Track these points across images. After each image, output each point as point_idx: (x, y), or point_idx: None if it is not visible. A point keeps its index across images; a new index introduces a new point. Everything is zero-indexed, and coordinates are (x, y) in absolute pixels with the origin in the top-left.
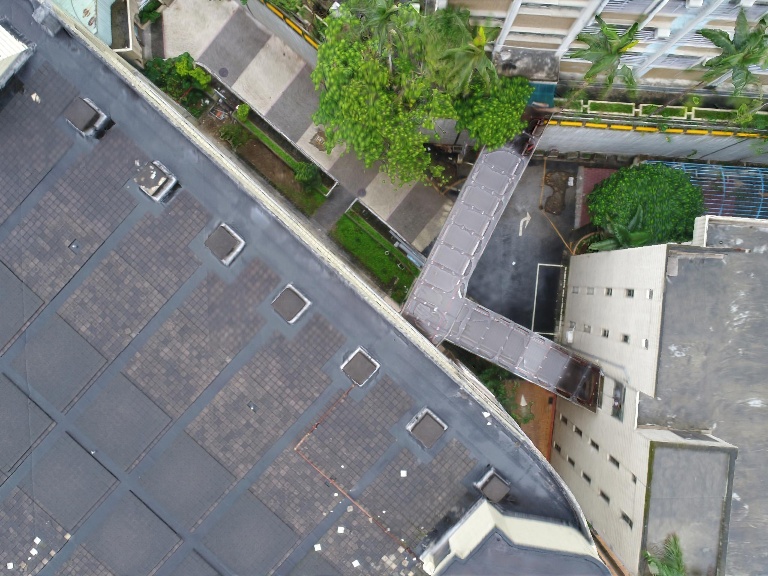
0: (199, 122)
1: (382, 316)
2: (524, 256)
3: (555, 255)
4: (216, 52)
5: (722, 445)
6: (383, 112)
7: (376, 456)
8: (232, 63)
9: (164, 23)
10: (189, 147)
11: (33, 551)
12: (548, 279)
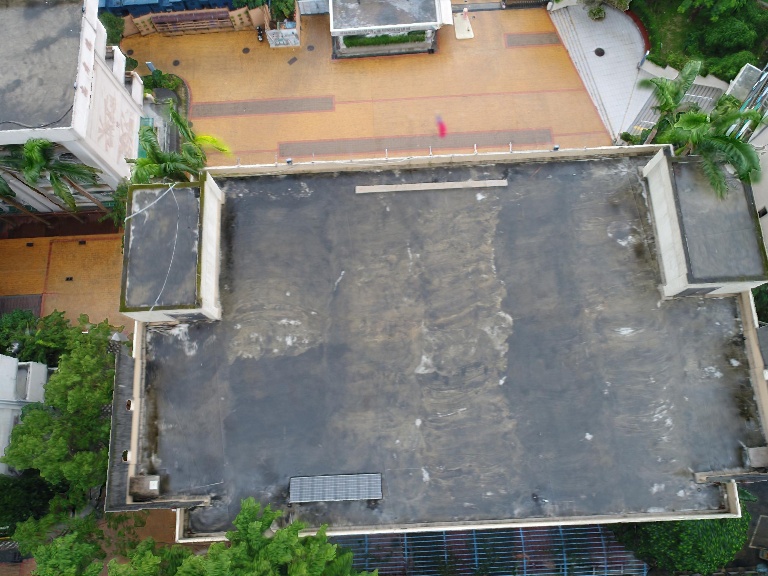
0: None
1: None
2: None
3: None
4: None
5: None
6: None
7: None
8: None
9: None
10: None
11: None
12: None
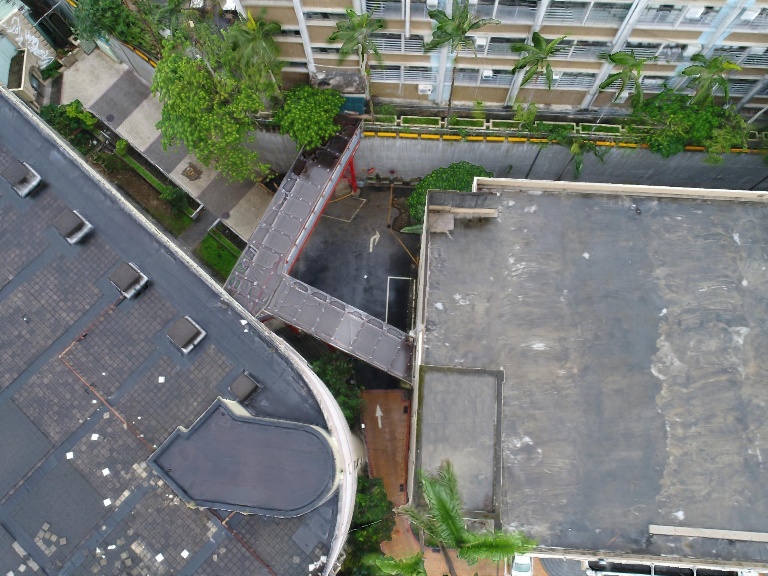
0: (86, 159)
1: (154, 236)
2: (375, 270)
3: (404, 269)
4: (105, 102)
5: (490, 369)
6: (201, 105)
7: (137, 363)
8: (118, 111)
9: (64, 80)
10: (6, 106)
11: None
12: (398, 291)
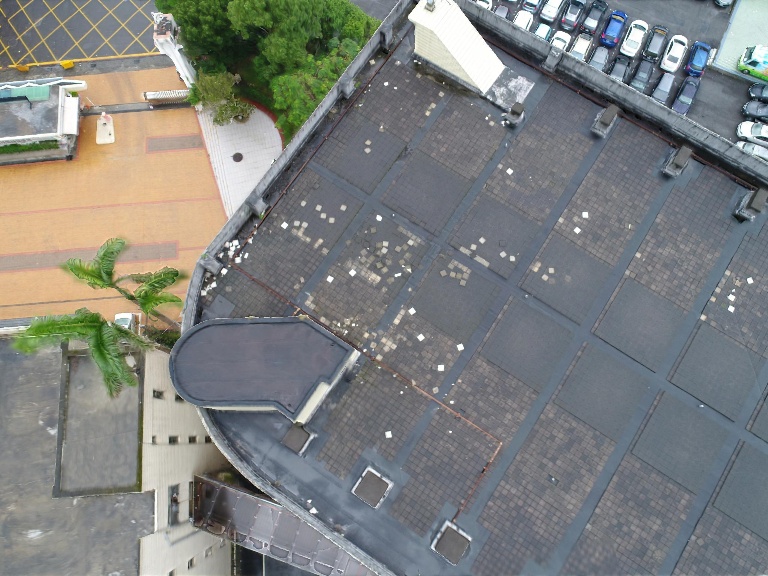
0: None
1: None
2: None
3: None
4: None
5: None
6: None
7: (419, 448)
8: None
9: None
10: None
11: (732, 298)
12: None
